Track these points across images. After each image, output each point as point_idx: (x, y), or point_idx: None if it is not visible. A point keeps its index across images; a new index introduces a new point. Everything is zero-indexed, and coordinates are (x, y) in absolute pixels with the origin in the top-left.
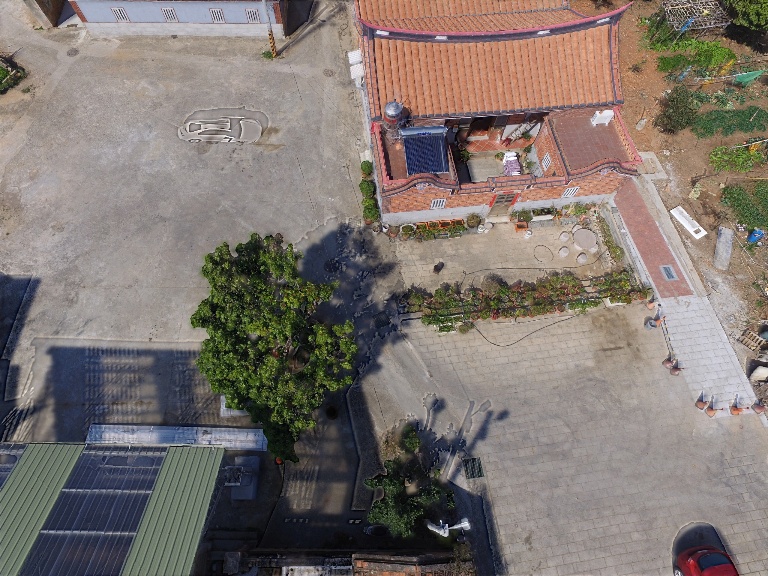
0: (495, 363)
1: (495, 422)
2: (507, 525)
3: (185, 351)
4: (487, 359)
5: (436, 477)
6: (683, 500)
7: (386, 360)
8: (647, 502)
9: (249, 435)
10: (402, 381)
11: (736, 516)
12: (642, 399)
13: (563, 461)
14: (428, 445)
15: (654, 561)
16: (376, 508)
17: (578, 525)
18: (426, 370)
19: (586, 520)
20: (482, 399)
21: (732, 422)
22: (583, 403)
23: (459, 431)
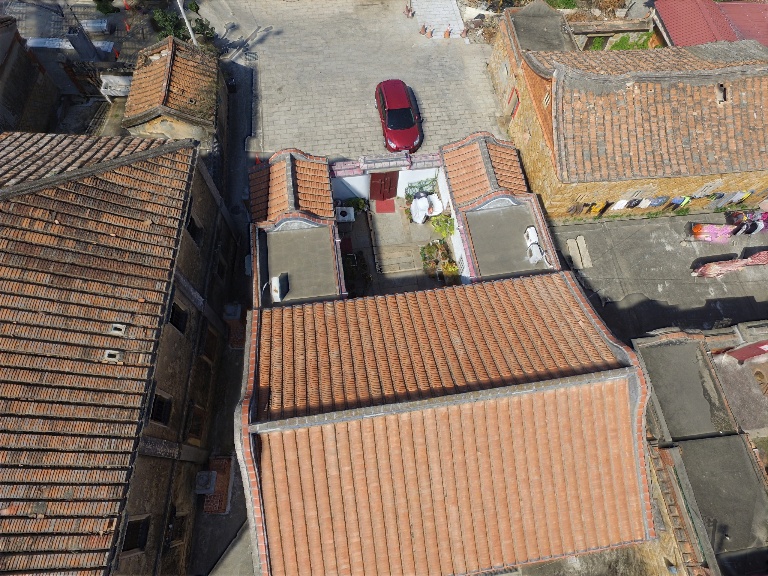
0: (282, 9)
1: (273, 36)
2: (267, 82)
3: (61, 4)
4: (276, 7)
5: (205, 23)
6: (394, 75)
7: (204, 7)
8: (368, 75)
9: (99, 43)
10: (212, 16)
11: (429, 83)
12: (382, 29)
13: (316, 55)
14: (222, 45)
15: (364, 101)
16: (160, 33)
17: (317, 84)
18: (231, 12)
19: (323, 82)
20: (267, 26)
21: (443, 41)
22: (339, 29)
23: (246, 39)
